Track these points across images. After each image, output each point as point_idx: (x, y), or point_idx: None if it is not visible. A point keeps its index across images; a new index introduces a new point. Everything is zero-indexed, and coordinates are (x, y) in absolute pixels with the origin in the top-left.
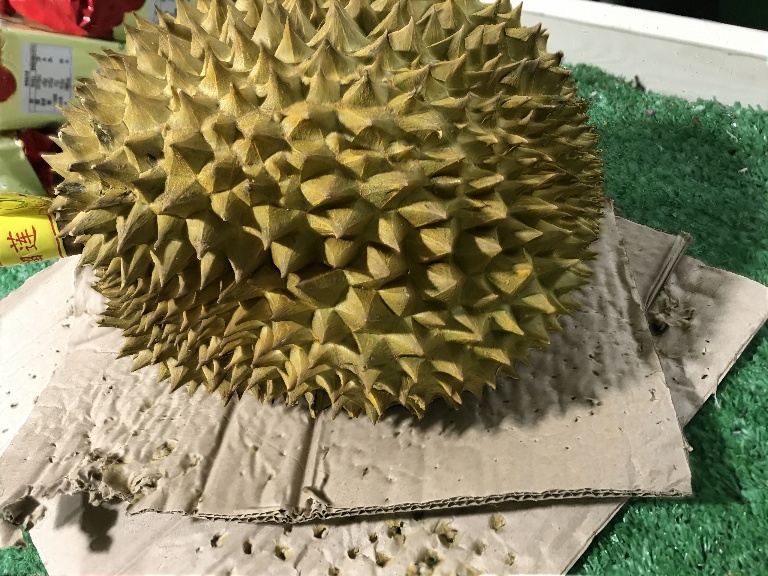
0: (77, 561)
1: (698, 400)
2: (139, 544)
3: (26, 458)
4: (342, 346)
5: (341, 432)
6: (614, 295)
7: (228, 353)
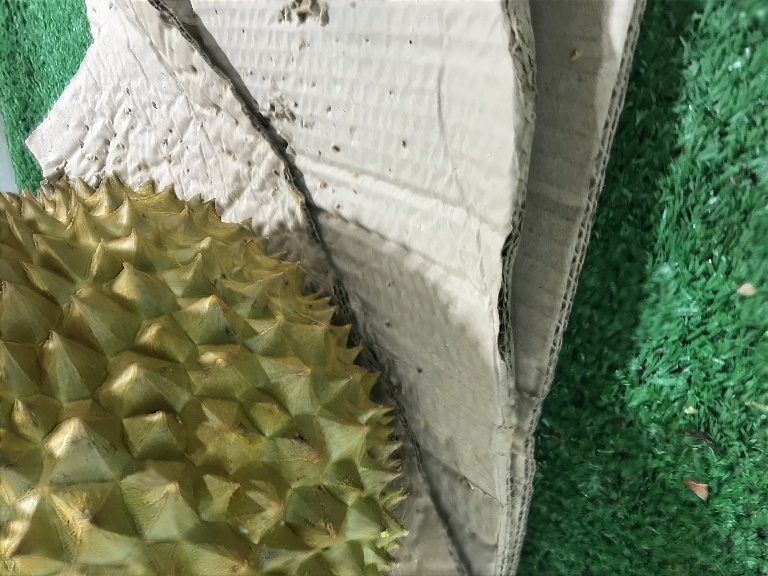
0: None
1: None
2: None
3: (69, 125)
4: None
5: None
6: None
7: None
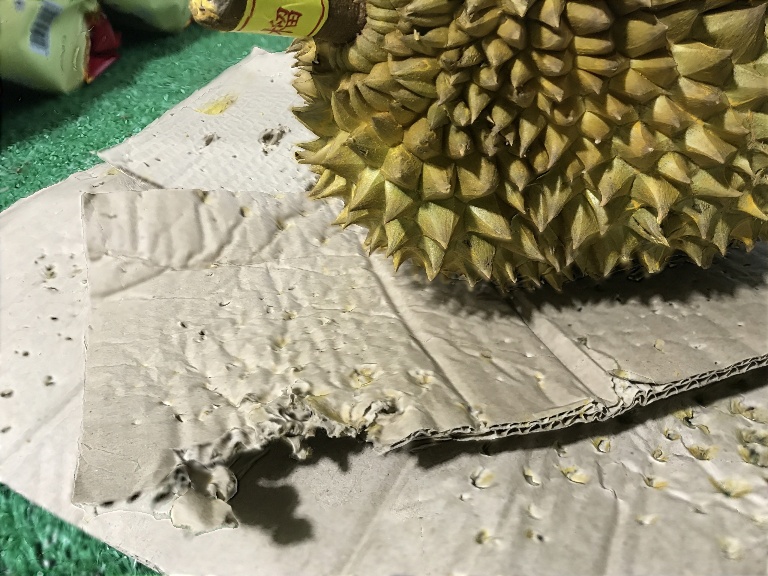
0: (261, 567)
1: None
2: (360, 516)
3: (133, 422)
4: (761, 113)
5: (583, 323)
6: None
7: (538, 177)
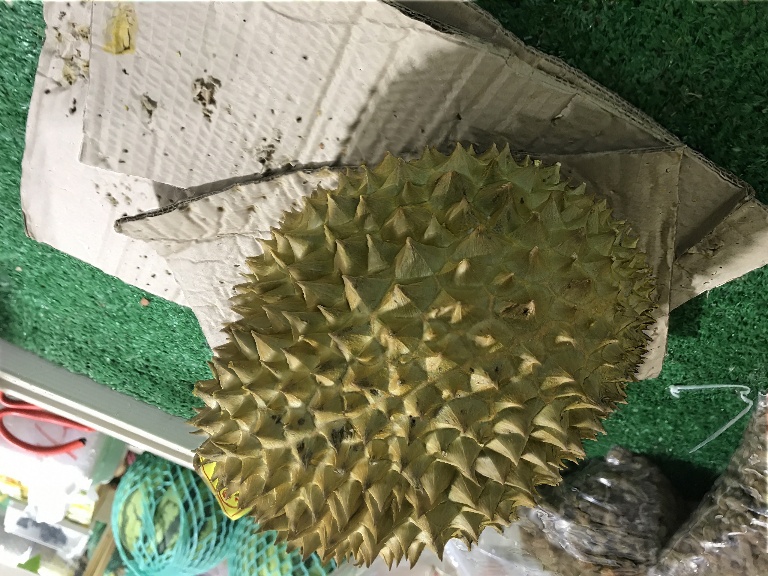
0: None
1: (694, 295)
2: None
3: None
4: None
5: None
6: (650, 256)
7: None
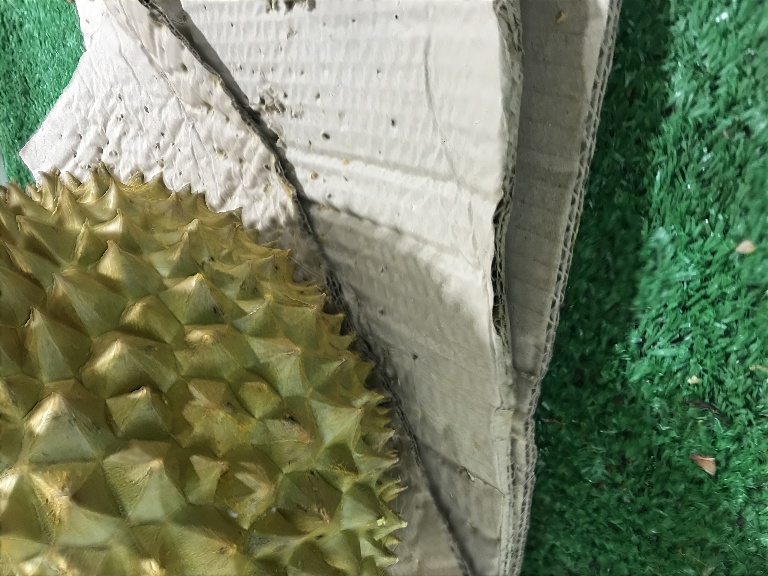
0: None
1: None
2: None
3: (62, 134)
4: None
5: None
6: None
7: None
